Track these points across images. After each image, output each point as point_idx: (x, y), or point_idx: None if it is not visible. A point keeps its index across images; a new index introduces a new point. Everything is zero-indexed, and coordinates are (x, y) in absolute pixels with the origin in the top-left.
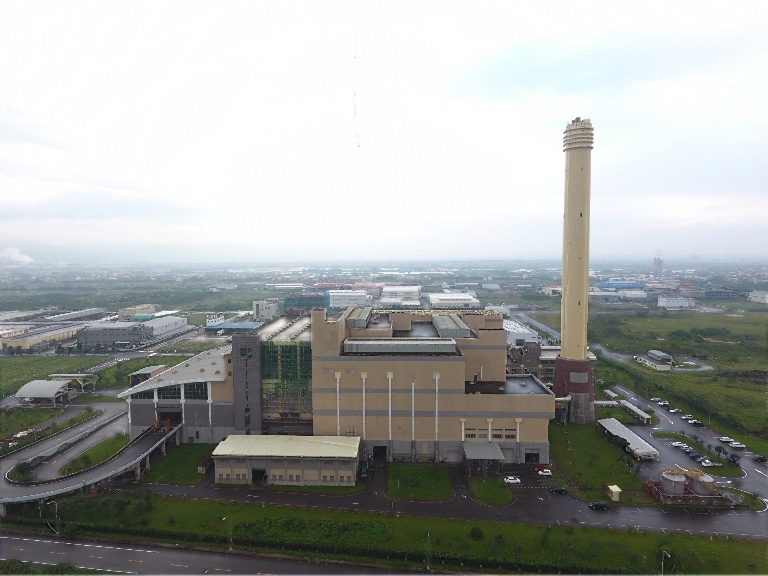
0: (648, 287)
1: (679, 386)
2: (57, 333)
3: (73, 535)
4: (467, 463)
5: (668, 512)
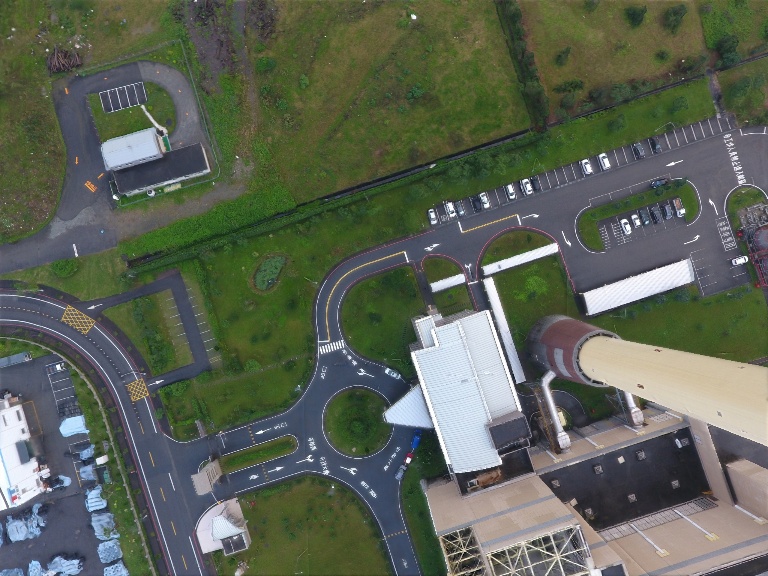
0: None
1: (334, 162)
2: None
3: None
4: None
5: None
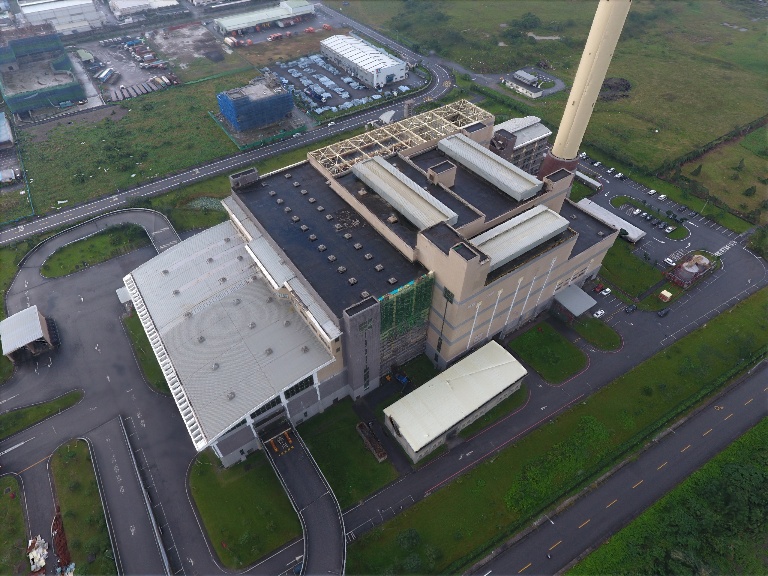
0: None
1: None
2: None
3: None
4: (565, 314)
5: (693, 296)
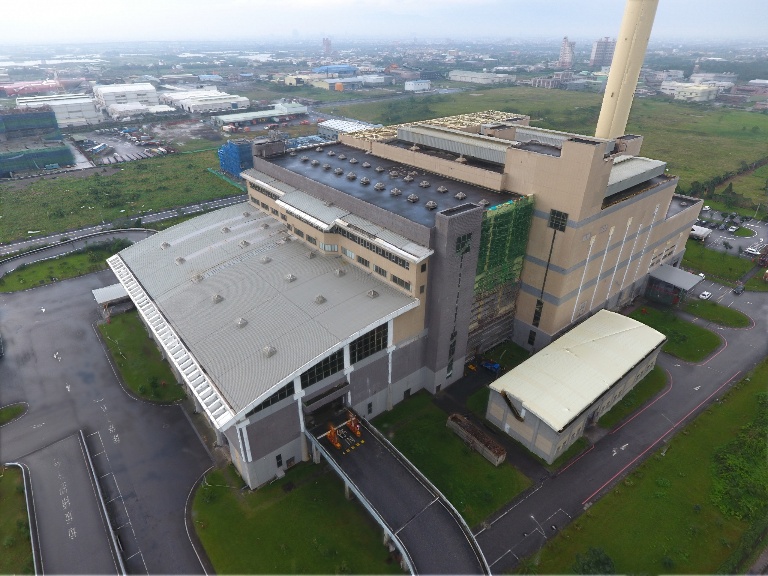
0: (359, 70)
1: None
2: None
3: None
4: (668, 294)
5: None
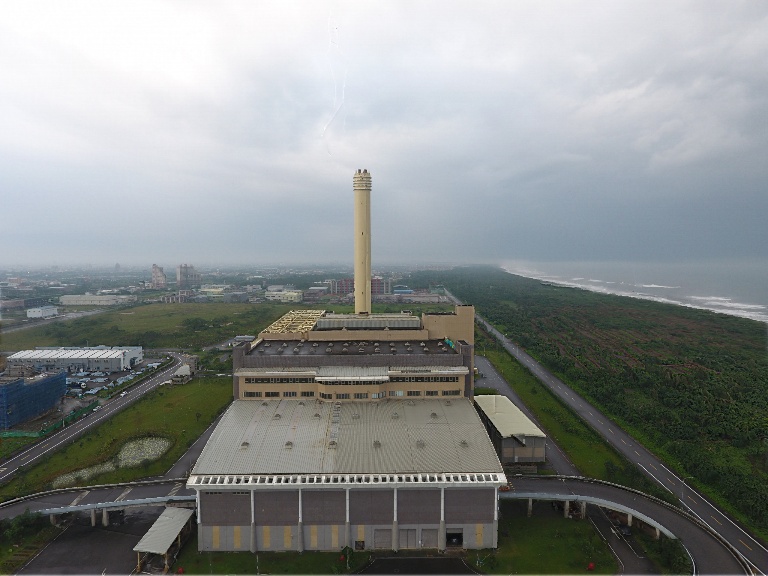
0: None
1: None
2: None
3: None
4: None
5: None
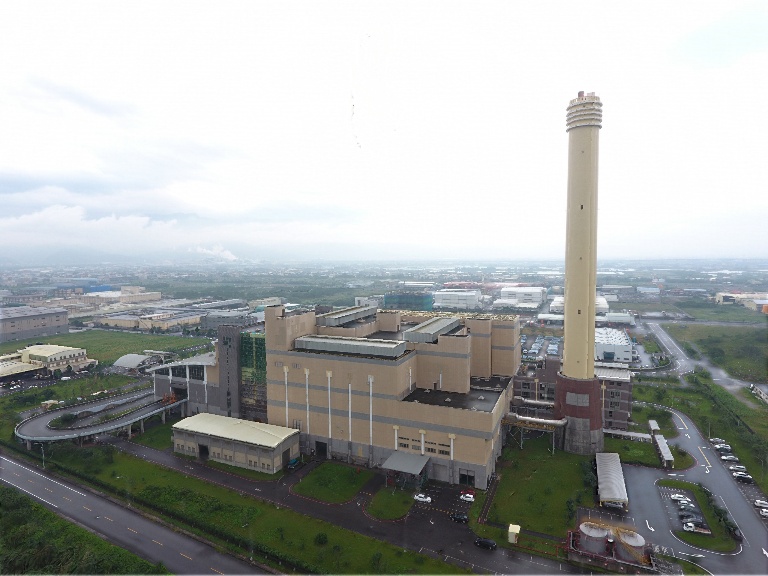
0: None
1: None
2: (191, 318)
3: (51, 471)
4: None
5: (565, 570)
